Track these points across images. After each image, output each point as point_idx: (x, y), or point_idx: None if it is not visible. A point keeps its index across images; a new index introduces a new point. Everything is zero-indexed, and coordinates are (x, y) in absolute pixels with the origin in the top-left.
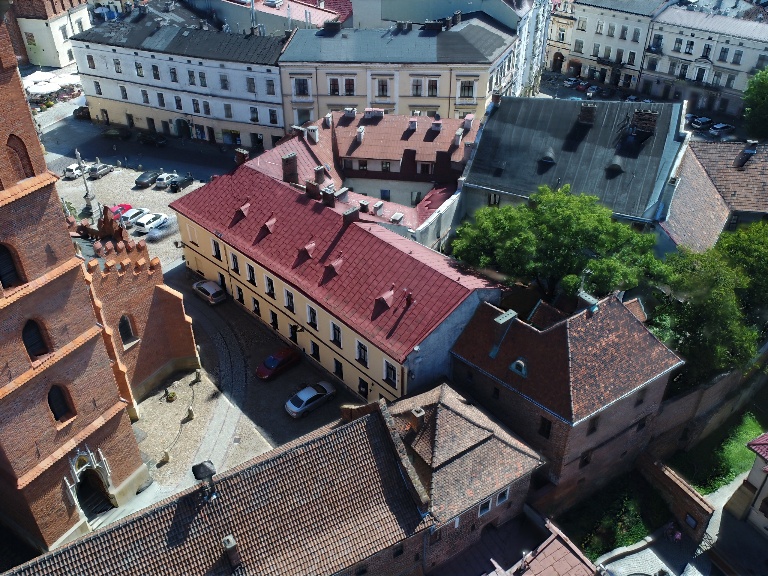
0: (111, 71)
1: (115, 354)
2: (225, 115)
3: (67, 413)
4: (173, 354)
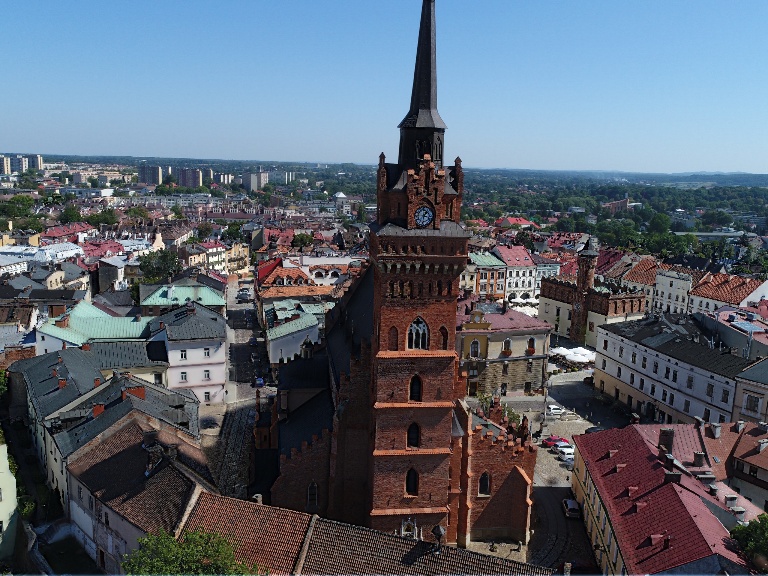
0: (616, 354)
1: (468, 491)
2: (684, 409)
3: (414, 492)
4: (512, 523)
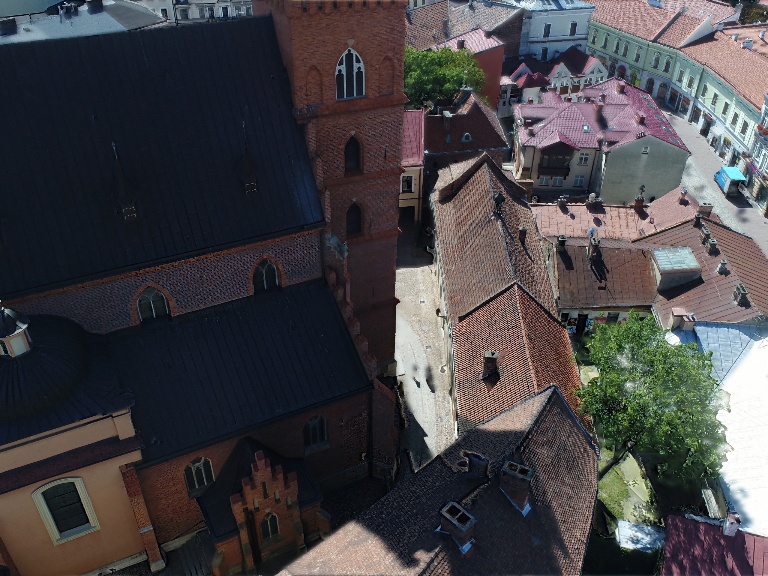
0: None
1: None
2: None
3: None
4: None
